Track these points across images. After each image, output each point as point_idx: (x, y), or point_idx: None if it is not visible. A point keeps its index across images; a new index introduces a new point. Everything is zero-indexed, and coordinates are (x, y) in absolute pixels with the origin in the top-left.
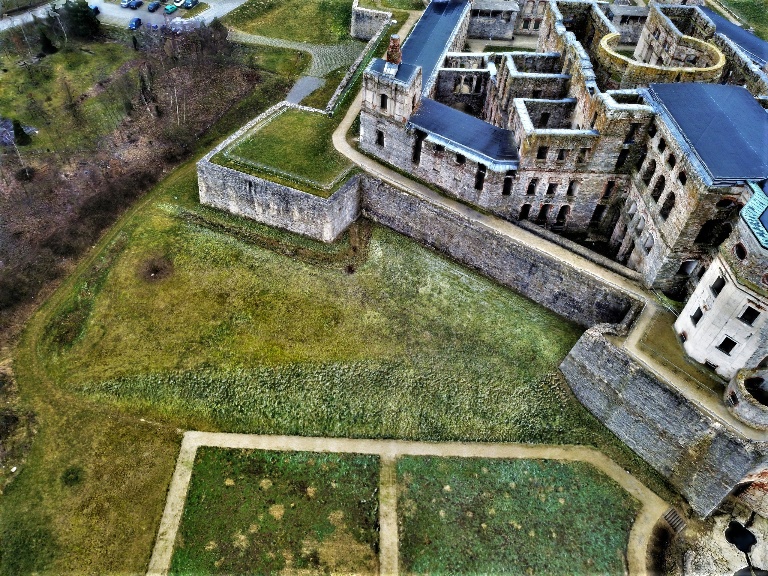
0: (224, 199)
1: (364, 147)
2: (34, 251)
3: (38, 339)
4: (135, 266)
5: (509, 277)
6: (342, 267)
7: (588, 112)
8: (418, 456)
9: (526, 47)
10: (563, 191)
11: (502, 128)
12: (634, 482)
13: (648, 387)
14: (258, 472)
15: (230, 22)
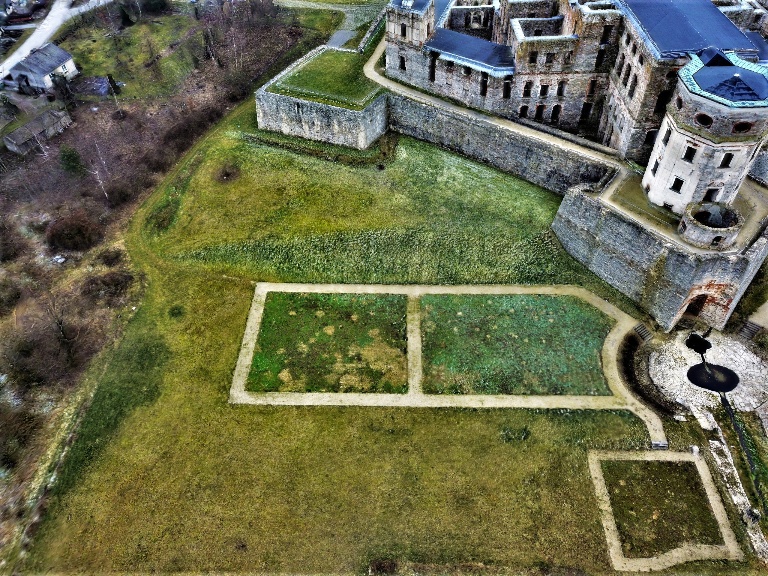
0: (277, 122)
1: (389, 73)
2: (132, 167)
3: (142, 226)
4: (211, 173)
5: (511, 164)
6: (374, 166)
7: (571, 23)
8: (437, 294)
9: None
10: (554, 92)
11: (502, 46)
12: (611, 307)
13: (616, 225)
14: (314, 306)
15: None
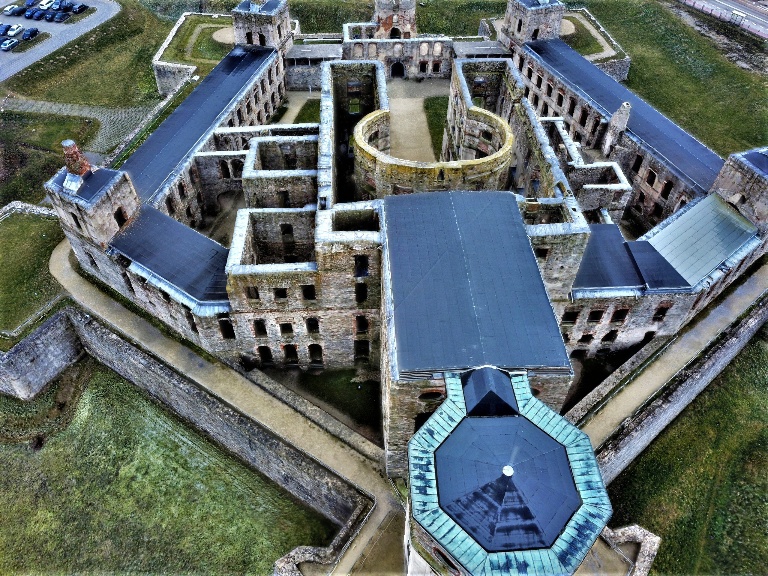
0: None
1: (84, 267)
2: None
3: None
4: None
5: (236, 447)
6: (31, 439)
7: None
8: None
9: None
10: (302, 330)
11: None
12: None
13: None
14: None
15: (15, 86)
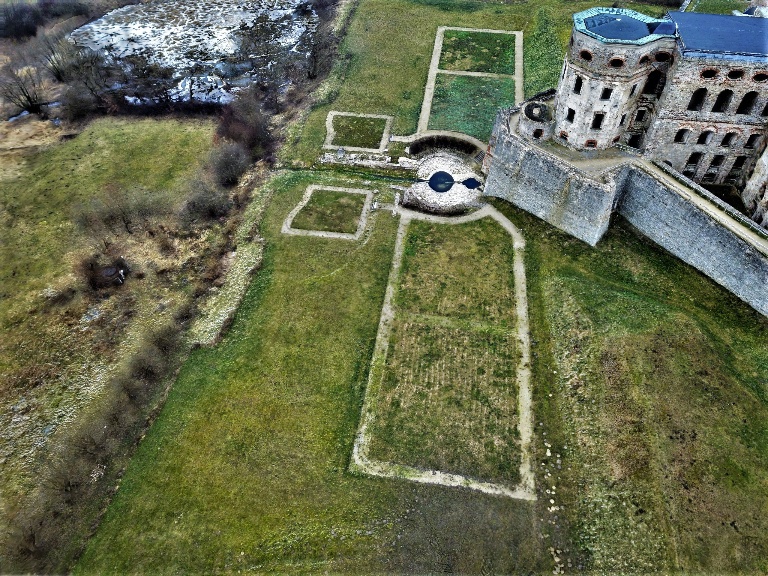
0: None
1: None
2: None
3: None
4: None
5: None
6: None
7: None
8: (514, 84)
9: None
10: None
11: None
12: None
13: None
14: None
15: None
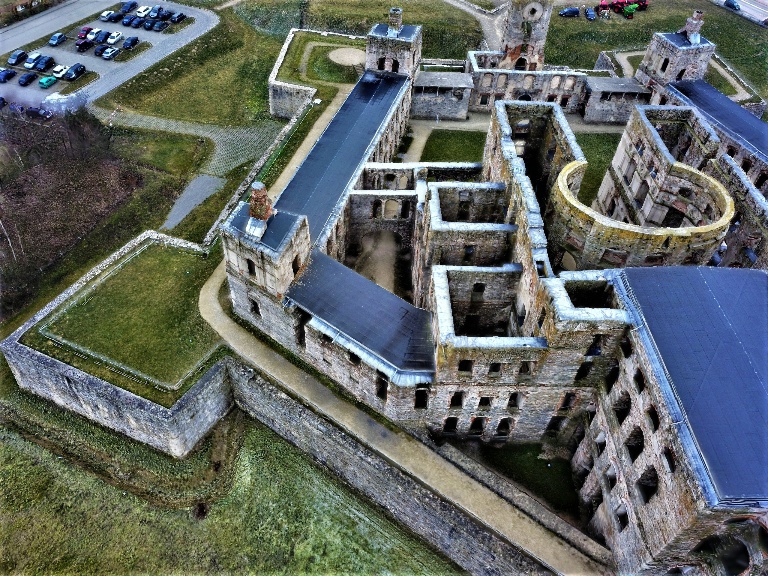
0: (44, 389)
1: (239, 312)
2: None
3: None
4: None
5: (424, 530)
6: (191, 505)
7: (535, 299)
8: None
9: (483, 130)
10: (502, 404)
11: None
12: None
13: None
14: None
15: (120, 98)
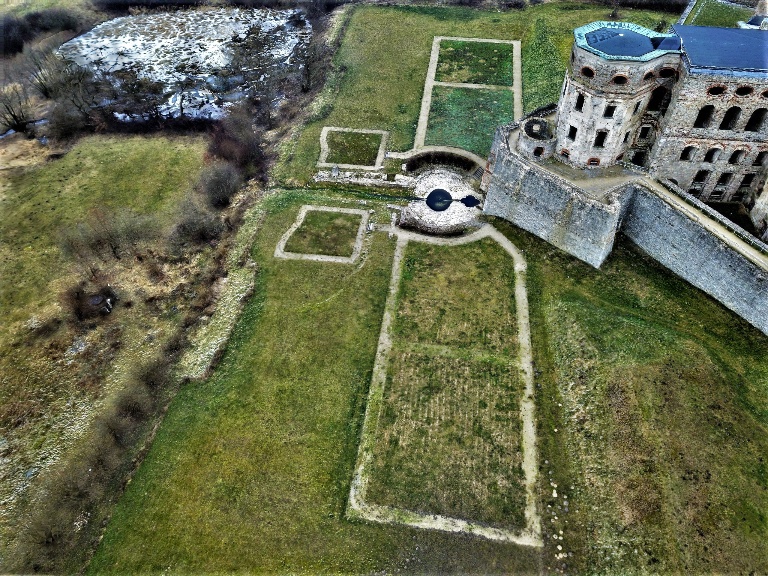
0: None
1: None
2: None
3: (565, 5)
4: None
5: None
6: None
7: None
8: (513, 96)
9: None
10: None
11: None
12: None
13: None
14: (501, 57)
15: None
